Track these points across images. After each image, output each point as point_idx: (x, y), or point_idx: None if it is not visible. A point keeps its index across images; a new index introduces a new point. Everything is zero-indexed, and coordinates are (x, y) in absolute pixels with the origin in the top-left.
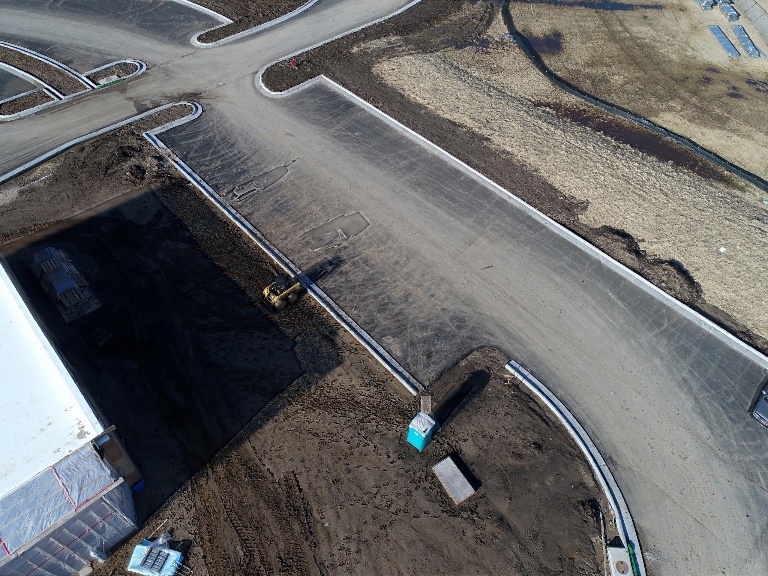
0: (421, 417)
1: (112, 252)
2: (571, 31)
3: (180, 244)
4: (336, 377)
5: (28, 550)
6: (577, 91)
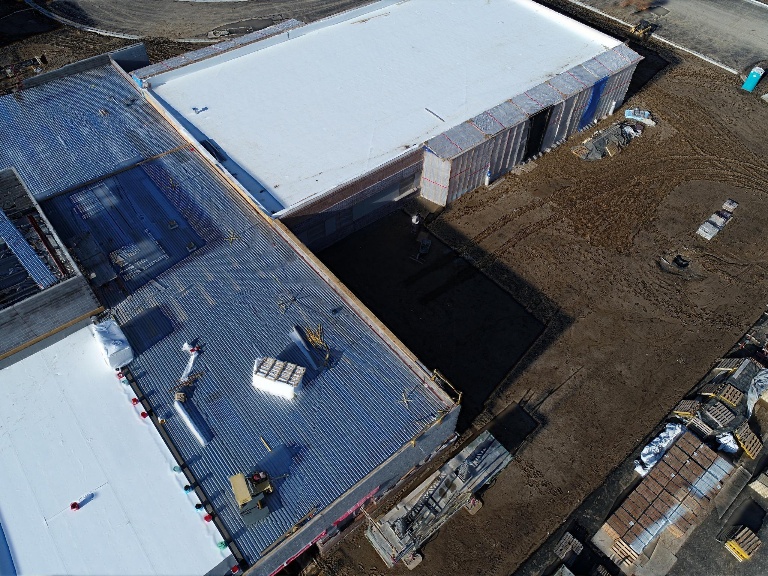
0: (757, 68)
1: None
2: None
3: None
4: (689, 66)
5: (616, 74)
6: None
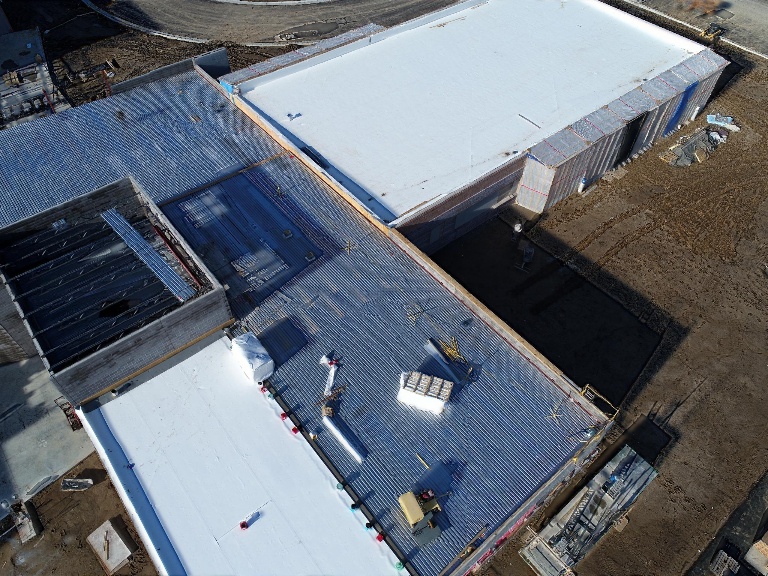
0: None
1: None
2: None
3: None
4: (763, 70)
5: None
6: None
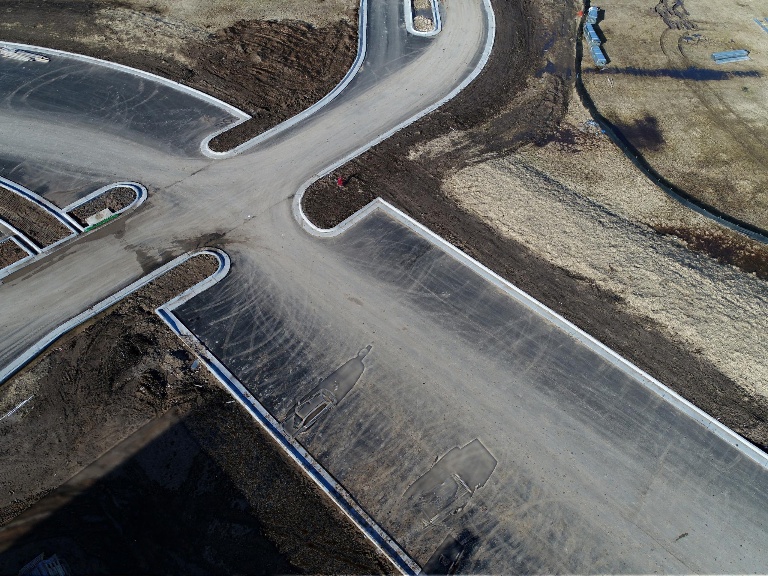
0: None
1: (135, 552)
2: (666, 113)
3: (235, 527)
4: None
5: None
6: (705, 209)
